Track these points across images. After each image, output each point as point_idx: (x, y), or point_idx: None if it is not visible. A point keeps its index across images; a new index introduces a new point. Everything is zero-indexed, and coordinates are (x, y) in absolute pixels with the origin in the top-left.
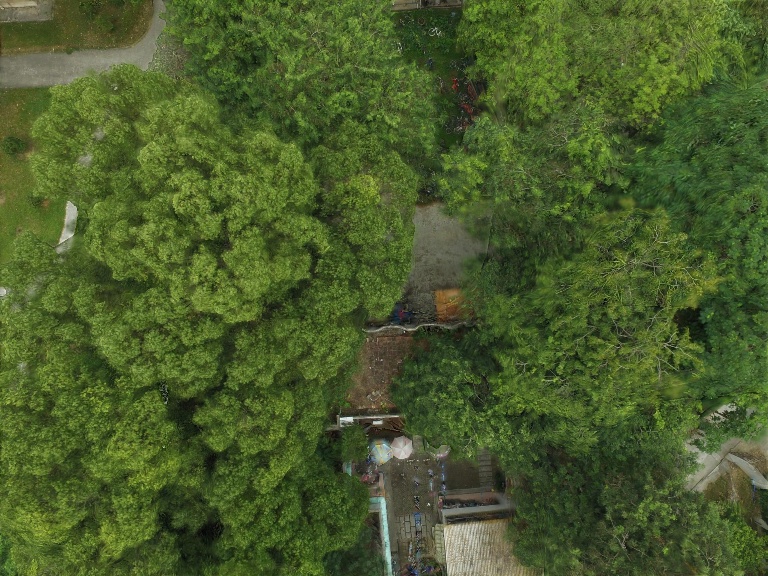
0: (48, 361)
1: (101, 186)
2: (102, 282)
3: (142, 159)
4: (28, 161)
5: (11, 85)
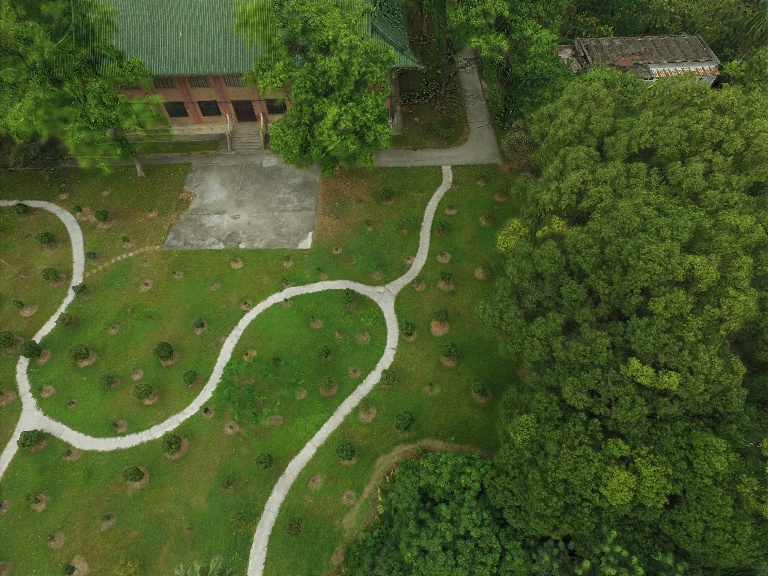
0: (629, 198)
1: (610, 127)
2: (645, 162)
3: (677, 90)
4: (389, 206)
5: (374, 166)
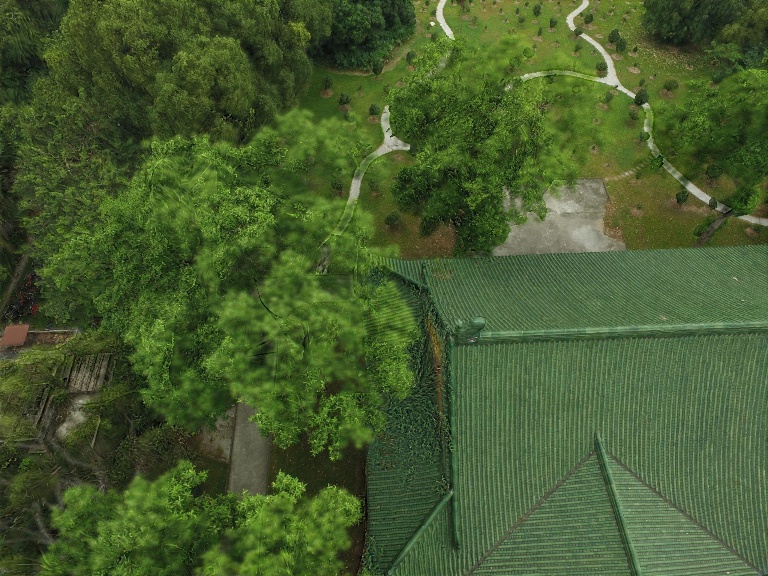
0: None
1: None
2: None
3: None
4: None
5: None
